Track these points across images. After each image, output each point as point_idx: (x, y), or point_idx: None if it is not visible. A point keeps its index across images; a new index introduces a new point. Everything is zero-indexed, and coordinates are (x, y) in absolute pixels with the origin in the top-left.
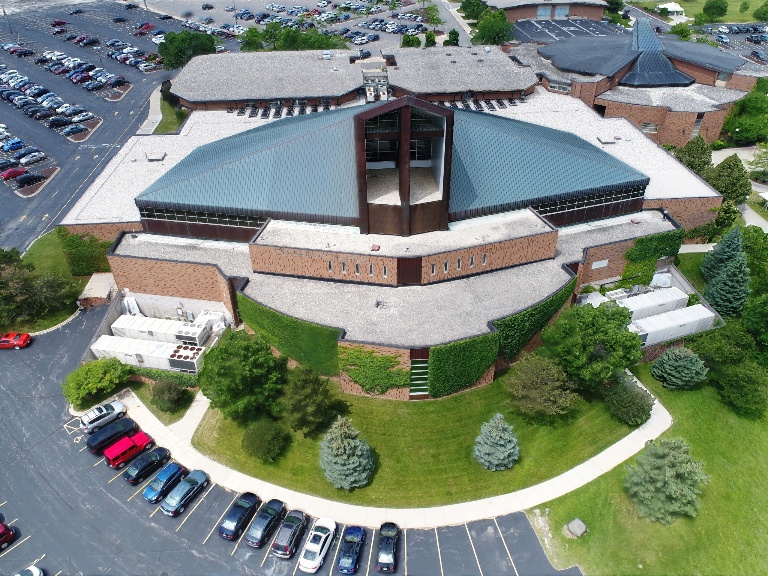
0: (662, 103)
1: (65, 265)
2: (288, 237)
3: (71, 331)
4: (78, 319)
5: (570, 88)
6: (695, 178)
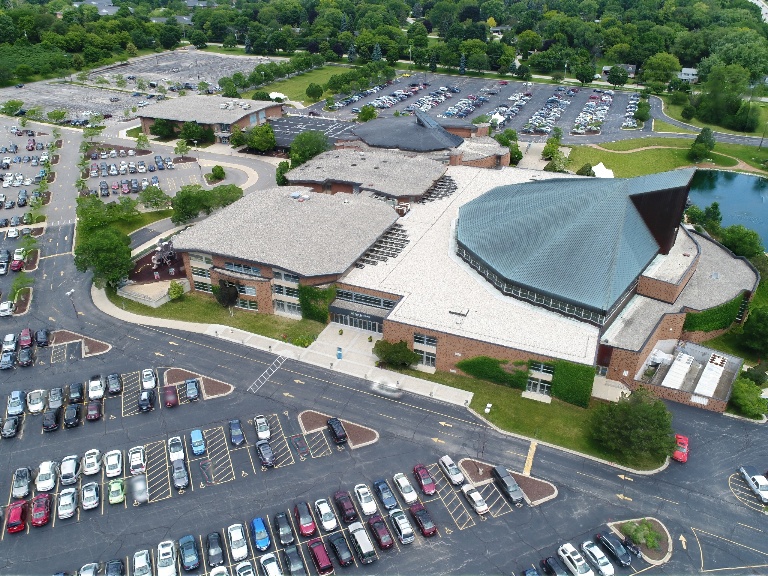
0: (486, 153)
1: (567, 411)
2: (667, 274)
3: None
4: None
5: (449, 161)
6: None
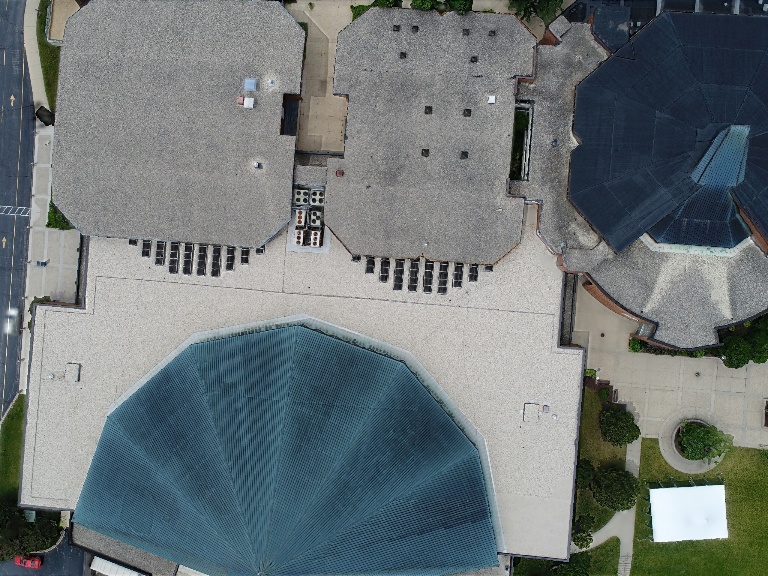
0: (659, 306)
1: None
2: None
3: (65, 553)
4: (66, 540)
5: None
6: (568, 521)
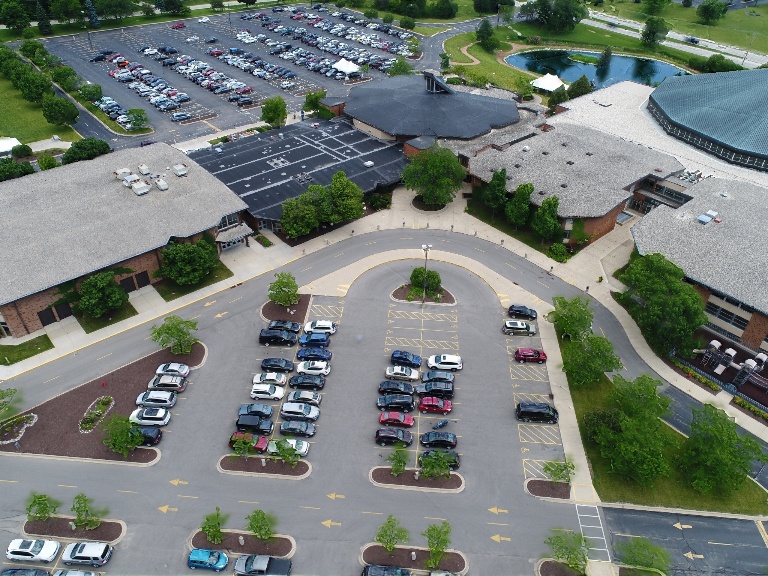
0: None
1: None
2: None
3: None
4: None
5: None
6: None
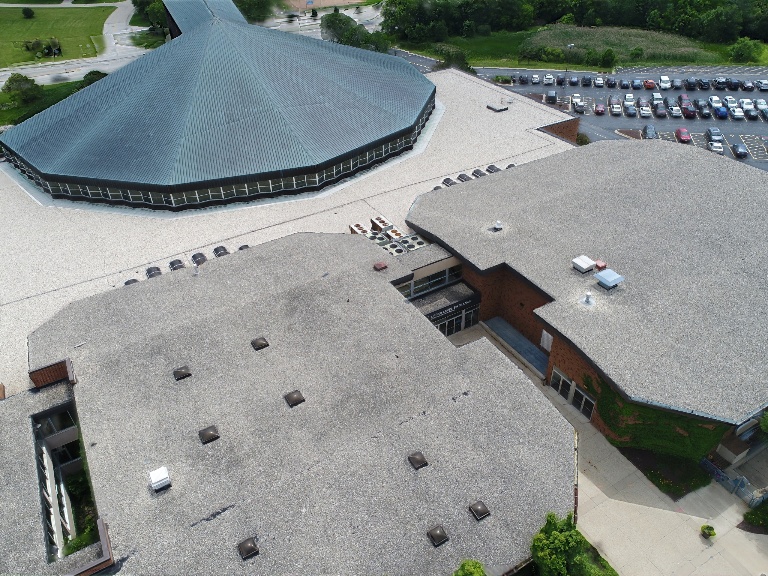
0: None
1: None
2: None
3: None
4: None
5: None
6: None
